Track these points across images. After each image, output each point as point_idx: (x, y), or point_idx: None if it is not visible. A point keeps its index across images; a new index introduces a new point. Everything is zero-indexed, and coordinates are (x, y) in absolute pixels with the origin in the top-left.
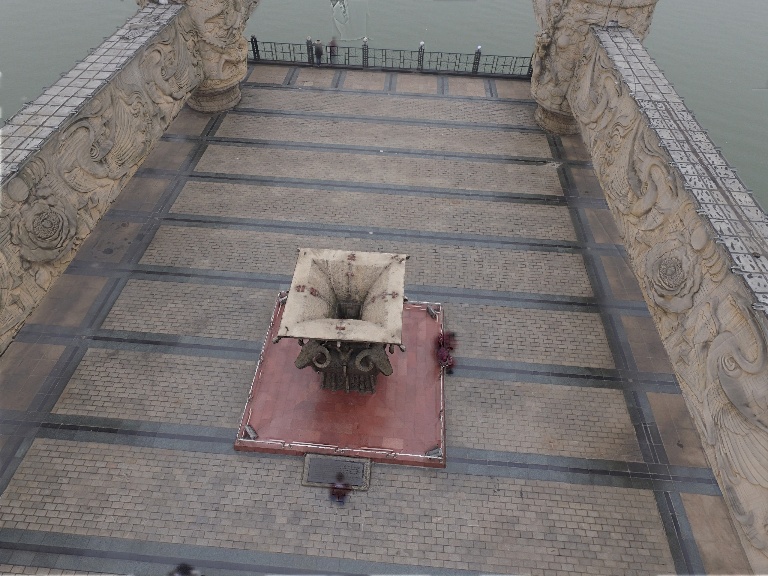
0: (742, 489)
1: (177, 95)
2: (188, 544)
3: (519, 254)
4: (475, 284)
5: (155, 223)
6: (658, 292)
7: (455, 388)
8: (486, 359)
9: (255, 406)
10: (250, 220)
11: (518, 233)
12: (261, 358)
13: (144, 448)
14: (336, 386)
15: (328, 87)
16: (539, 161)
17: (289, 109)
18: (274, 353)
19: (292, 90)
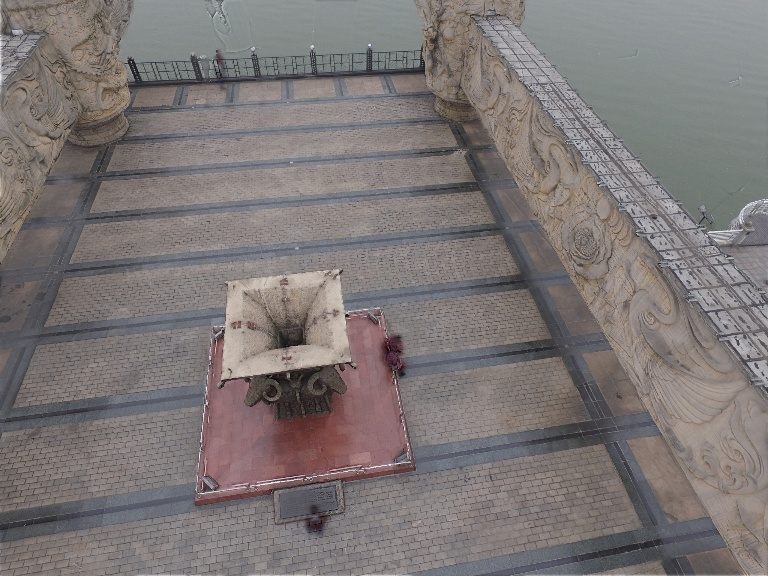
0: (679, 428)
1: (54, 134)
2: None
3: (445, 245)
4: (409, 282)
5: (56, 278)
6: (577, 262)
7: (410, 389)
8: (434, 354)
9: (209, 454)
10: (165, 256)
11: (440, 224)
12: (206, 402)
13: (92, 529)
14: (291, 414)
15: (223, 103)
16: (447, 151)
17: (185, 131)
18: (219, 393)
19: (184, 110)
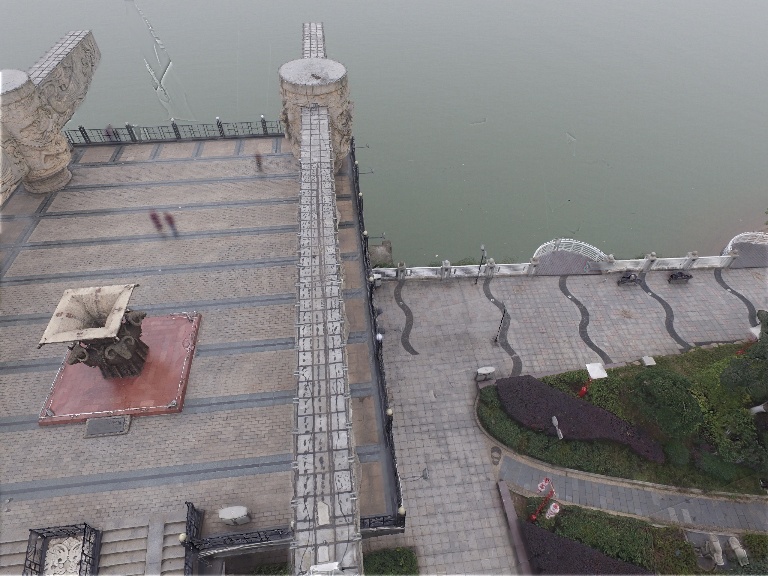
0: None
1: (1, 190)
2: (2, 484)
3: (265, 270)
4: (228, 295)
5: None
6: None
7: (198, 364)
8: (224, 343)
9: (55, 397)
10: (68, 274)
11: (268, 255)
12: None
13: None
14: (113, 375)
15: (146, 160)
16: None
17: (111, 182)
18: None
19: (116, 166)
